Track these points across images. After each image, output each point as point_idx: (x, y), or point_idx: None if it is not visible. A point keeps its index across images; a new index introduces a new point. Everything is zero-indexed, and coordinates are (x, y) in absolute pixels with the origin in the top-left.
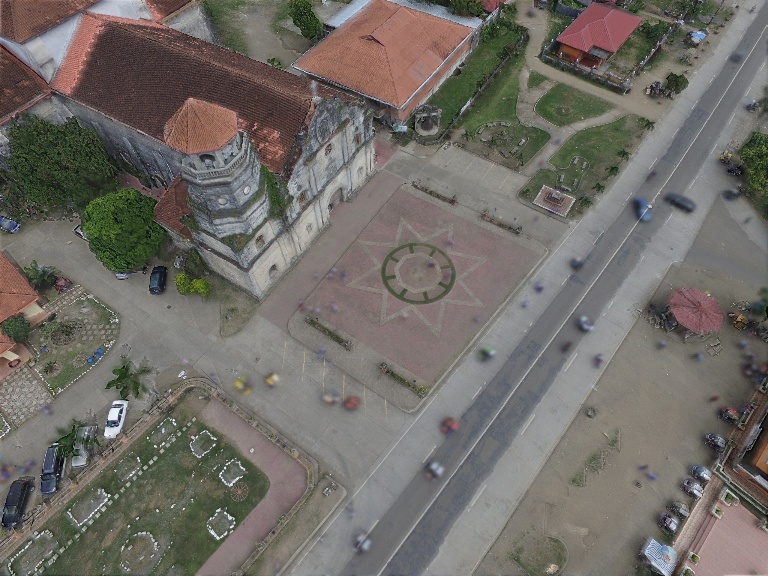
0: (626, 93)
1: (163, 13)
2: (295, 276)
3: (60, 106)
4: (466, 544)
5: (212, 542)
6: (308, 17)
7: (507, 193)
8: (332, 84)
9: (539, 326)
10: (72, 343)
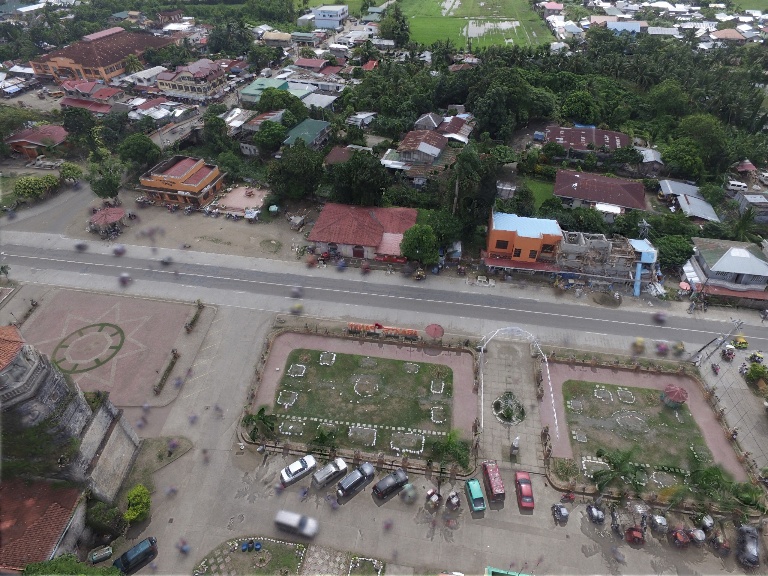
0: None
1: None
2: None
3: None
4: (278, 267)
5: (339, 357)
6: None
7: None
8: None
9: (130, 276)
10: None
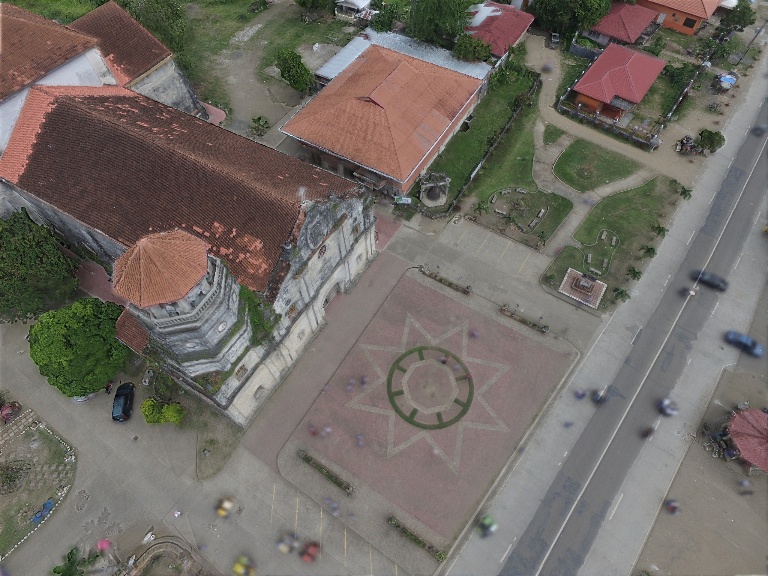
0: (654, 150)
1: (131, 75)
2: (285, 393)
3: (9, 192)
4: None
5: None
6: (298, 70)
7: (528, 278)
8: (326, 152)
9: (575, 456)
10: (18, 491)
